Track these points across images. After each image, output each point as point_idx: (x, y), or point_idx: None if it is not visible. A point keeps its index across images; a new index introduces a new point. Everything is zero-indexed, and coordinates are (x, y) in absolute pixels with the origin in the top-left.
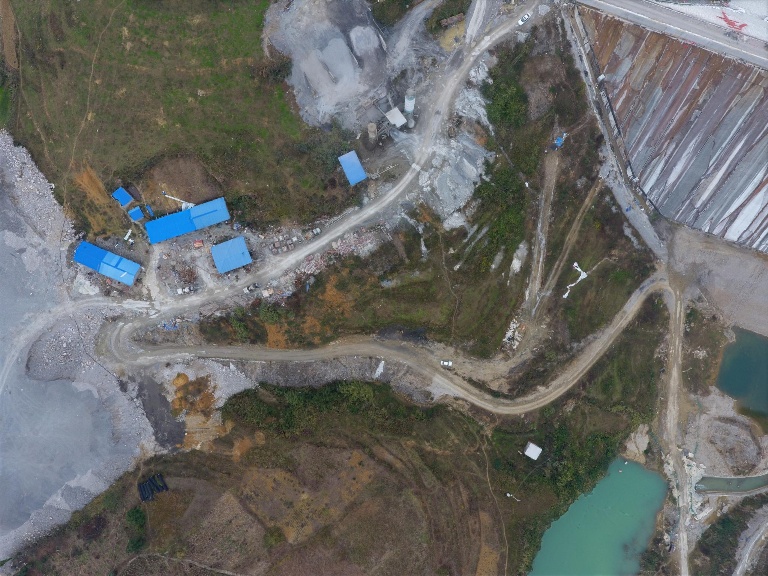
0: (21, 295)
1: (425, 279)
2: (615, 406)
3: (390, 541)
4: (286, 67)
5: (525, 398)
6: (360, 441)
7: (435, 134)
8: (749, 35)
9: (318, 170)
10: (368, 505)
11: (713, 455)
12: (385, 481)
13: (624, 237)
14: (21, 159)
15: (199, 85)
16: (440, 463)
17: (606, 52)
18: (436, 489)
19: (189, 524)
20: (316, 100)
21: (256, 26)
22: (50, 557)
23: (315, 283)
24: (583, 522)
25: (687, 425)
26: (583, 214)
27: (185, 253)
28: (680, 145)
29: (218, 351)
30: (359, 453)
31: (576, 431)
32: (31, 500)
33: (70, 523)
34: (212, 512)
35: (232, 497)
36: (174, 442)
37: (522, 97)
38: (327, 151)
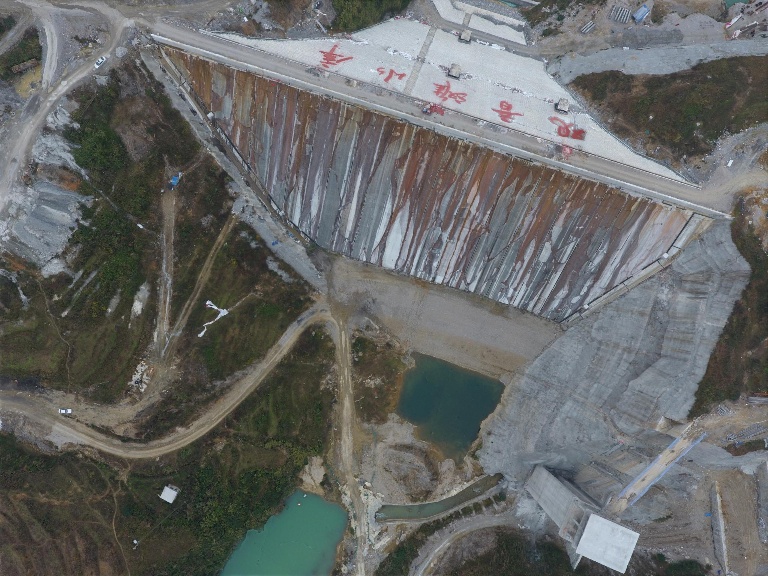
0: None
1: (29, 328)
2: (269, 442)
3: None
4: None
5: (161, 440)
6: None
7: (11, 182)
8: (330, 71)
9: None
10: None
11: (390, 483)
12: None
13: (268, 272)
14: None
15: None
16: (55, 514)
17: (205, 91)
18: (45, 542)
19: None
20: None
21: None
22: None
23: None
24: (260, 558)
25: (362, 454)
26: (216, 251)
27: None
28: (307, 179)
29: None
30: None
31: (226, 470)
32: None
33: None
34: None
35: None
36: None
37: (116, 140)
38: None
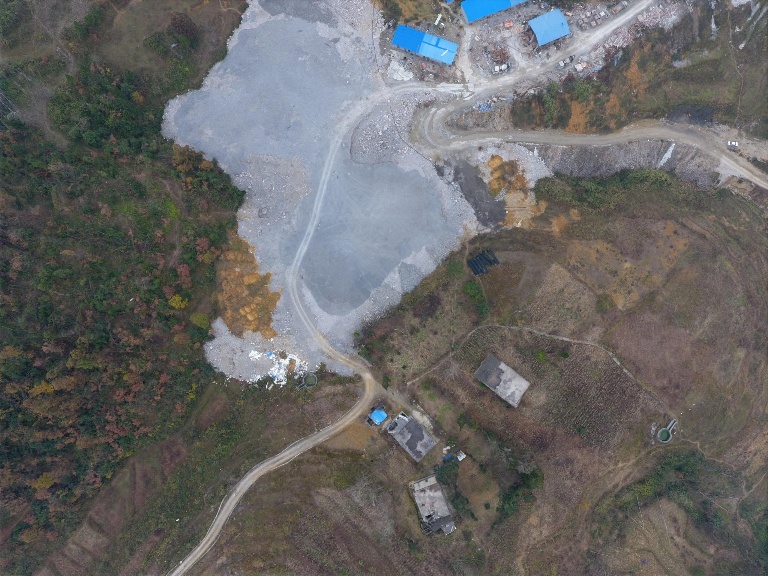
0: (338, 83)
1: (715, 57)
2: None
3: (711, 305)
4: None
5: None
6: (669, 214)
7: None
8: None
9: None
10: (687, 271)
11: None
12: (700, 248)
13: None
14: None
15: None
16: None
17: None
18: (742, 259)
19: (525, 293)
20: None
21: None
22: (388, 336)
23: (623, 57)
24: None
25: None
26: None
27: (495, 34)
28: None
29: (523, 136)
30: (672, 223)
31: None
32: (372, 277)
33: (401, 305)
34: (545, 281)
35: (561, 267)
36: (496, 220)
37: None
38: None
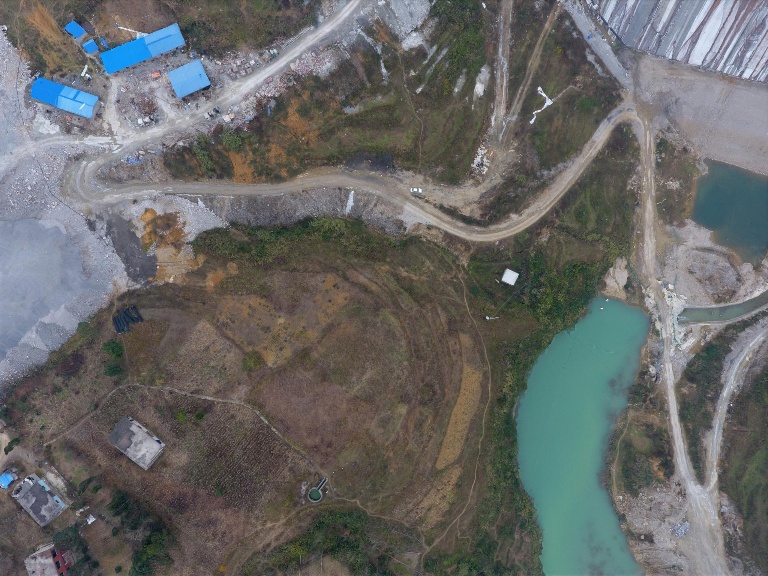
0: None
1: (388, 103)
2: (590, 234)
3: (370, 360)
4: None
5: (498, 226)
6: (334, 266)
7: None
8: None
9: None
10: (346, 326)
11: (693, 285)
12: (361, 302)
13: (587, 63)
14: None
15: None
16: (416, 287)
17: None
18: (413, 311)
19: (166, 352)
20: None
21: None
22: (30, 396)
23: (276, 106)
24: (568, 361)
25: (665, 257)
26: (544, 38)
27: (143, 85)
28: None
29: (185, 187)
30: (333, 276)
31: (553, 260)
32: (5, 337)
33: (48, 363)
34: (189, 339)
35: (208, 324)
36: (146, 276)
37: None
38: None
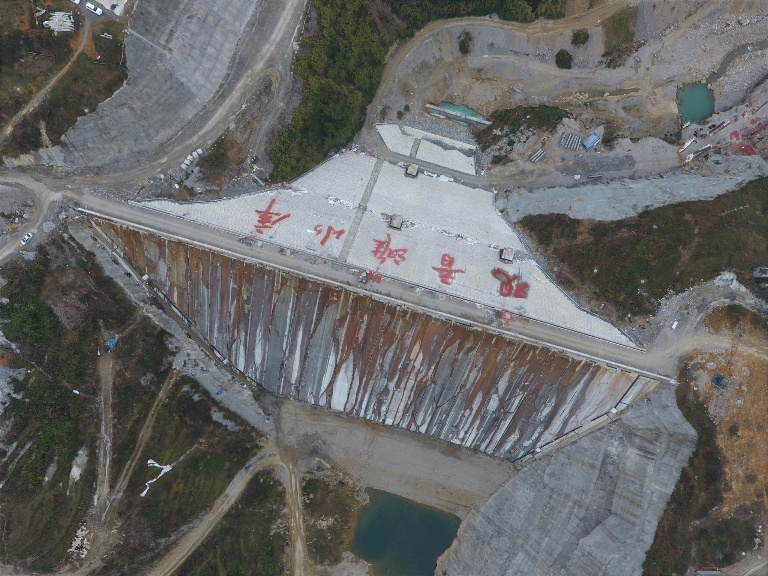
0: None
1: None
2: None
3: None
4: None
5: None
6: None
7: None
8: (263, 240)
9: None
10: None
11: None
12: None
13: (212, 423)
14: None
15: None
16: None
17: (139, 256)
18: None
19: None
20: None
21: None
22: None
23: None
24: None
25: None
26: (157, 408)
27: None
28: (249, 333)
29: None
30: None
31: None
32: None
33: None
34: None
35: None
36: None
37: (47, 311)
38: None
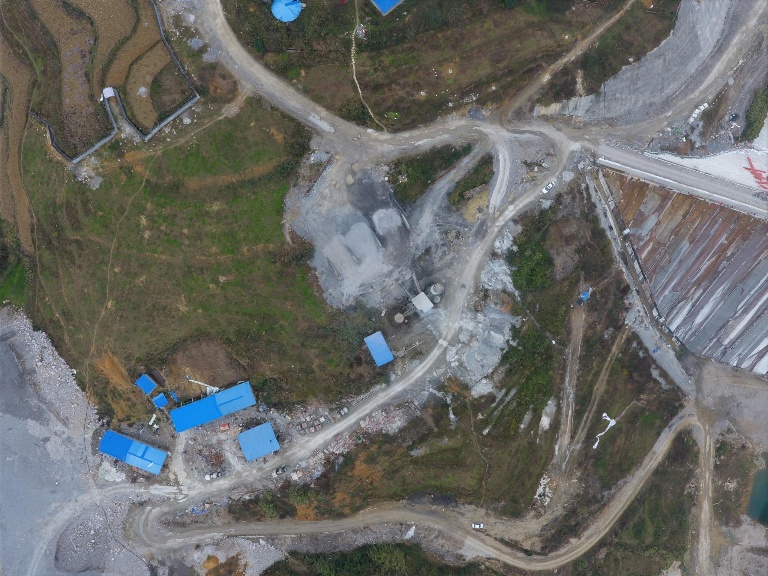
0: (47, 485)
1: (454, 446)
2: (648, 550)
3: None
4: (308, 253)
5: (557, 552)
6: None
7: (461, 308)
8: None
9: (343, 349)
10: None
11: None
12: None
13: (652, 380)
14: (41, 343)
15: (220, 271)
16: None
17: (631, 209)
18: None
19: None
20: (340, 282)
21: (276, 211)
22: None
23: (344, 462)
24: None
25: (719, 558)
26: (610, 363)
27: (211, 436)
28: (707, 291)
29: (247, 528)
30: None
31: None
32: None
33: None
34: None
35: None
36: None
37: (547, 260)
38: (352, 333)
